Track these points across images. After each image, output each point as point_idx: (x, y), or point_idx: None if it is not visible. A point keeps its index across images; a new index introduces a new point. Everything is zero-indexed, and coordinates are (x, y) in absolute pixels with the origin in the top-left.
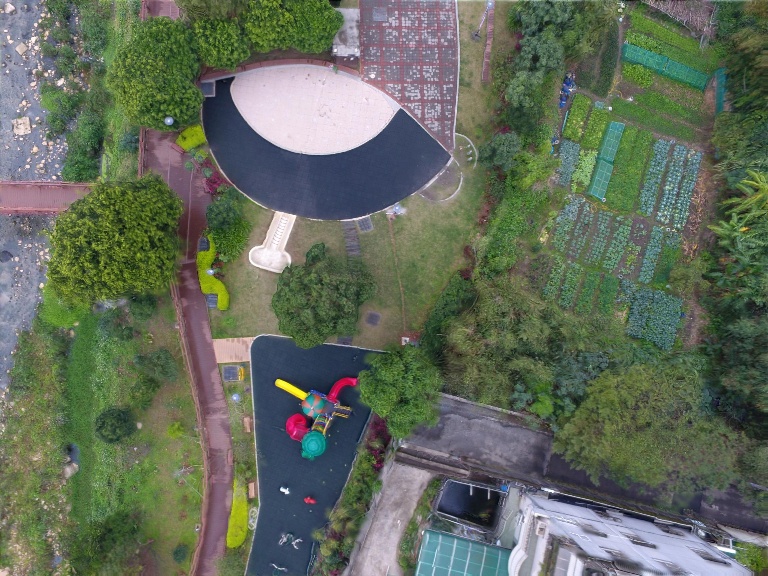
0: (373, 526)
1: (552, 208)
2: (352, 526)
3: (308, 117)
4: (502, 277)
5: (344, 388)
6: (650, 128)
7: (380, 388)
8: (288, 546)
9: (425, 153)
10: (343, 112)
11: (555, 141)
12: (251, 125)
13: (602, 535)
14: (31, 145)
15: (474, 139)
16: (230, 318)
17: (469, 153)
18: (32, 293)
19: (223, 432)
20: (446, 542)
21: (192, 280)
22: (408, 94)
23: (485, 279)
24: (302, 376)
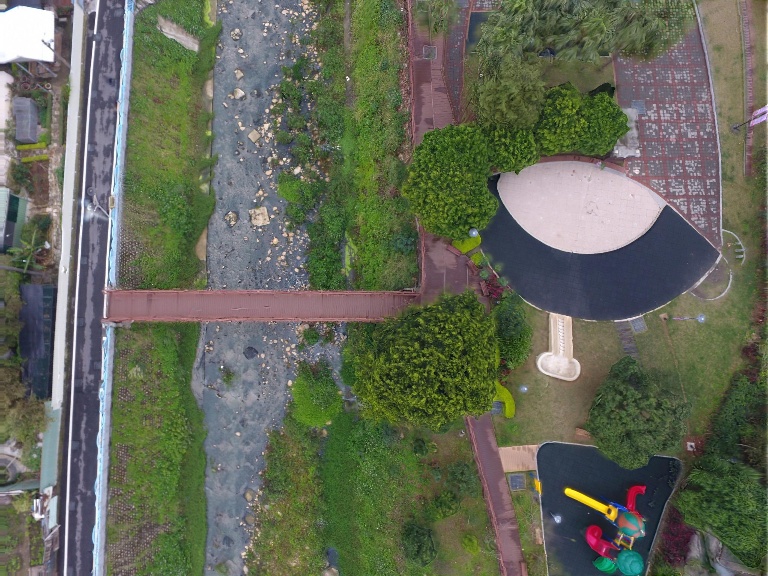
0: None
1: None
2: None
3: (576, 215)
4: None
5: (637, 498)
6: None
7: (736, 520)
8: None
9: (694, 251)
10: (610, 209)
11: None
12: (520, 224)
13: None
14: (270, 236)
15: (741, 235)
16: (514, 425)
17: (739, 251)
18: (280, 391)
19: (514, 544)
20: None
21: None
22: (673, 190)
23: (767, 382)
24: (590, 484)
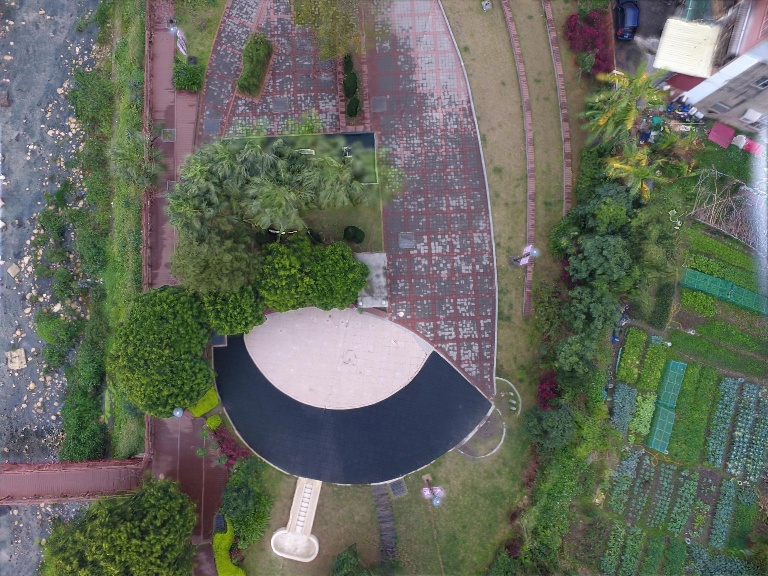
0: None
1: (608, 463)
2: None
3: (331, 365)
4: None
5: None
6: (715, 363)
7: None
8: None
9: (463, 402)
10: (370, 358)
11: (608, 385)
12: (268, 377)
13: None
14: (27, 381)
15: (517, 383)
16: None
17: (512, 402)
18: (33, 550)
19: None
20: None
21: (209, 564)
22: (441, 333)
23: (536, 554)
24: None
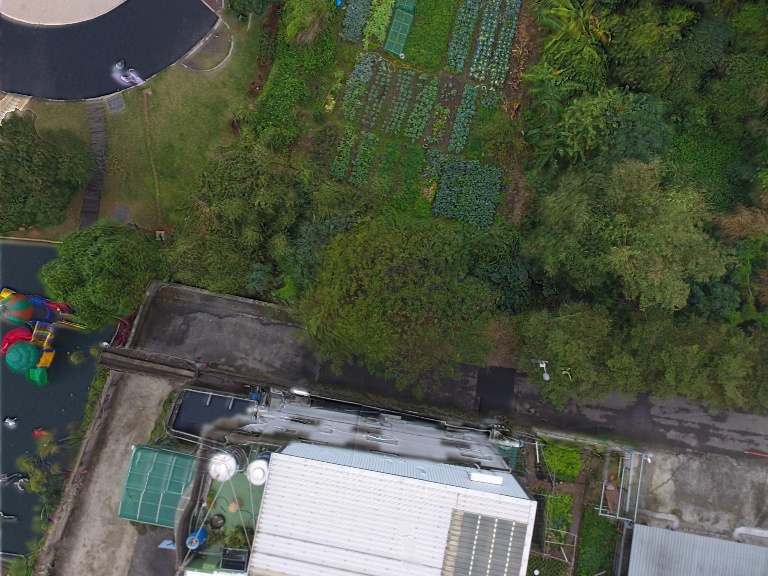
0: (101, 454)
1: (340, 70)
2: (57, 451)
3: None
4: (279, 154)
5: None
6: None
7: (55, 265)
8: (11, 488)
9: (187, 16)
10: None
11: None
12: None
13: (326, 431)
14: None
15: None
16: None
17: None
18: None
19: None
20: (162, 461)
21: None
22: None
23: None
24: (35, 284)
